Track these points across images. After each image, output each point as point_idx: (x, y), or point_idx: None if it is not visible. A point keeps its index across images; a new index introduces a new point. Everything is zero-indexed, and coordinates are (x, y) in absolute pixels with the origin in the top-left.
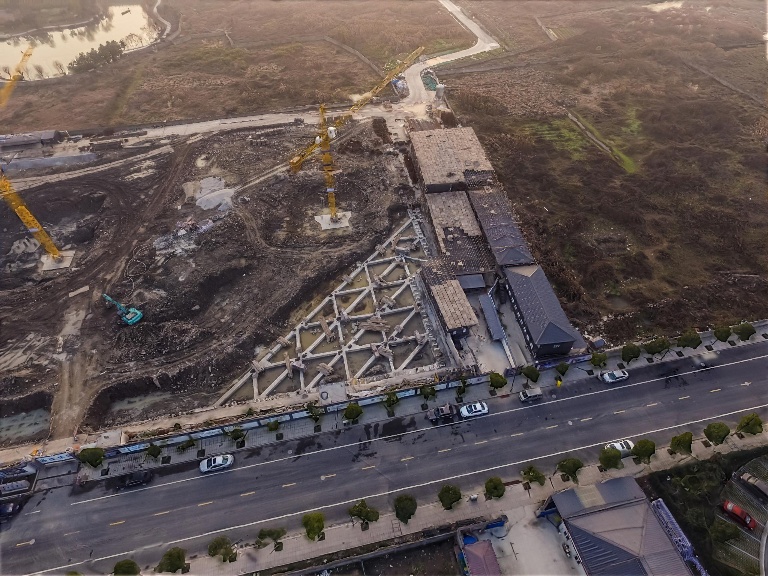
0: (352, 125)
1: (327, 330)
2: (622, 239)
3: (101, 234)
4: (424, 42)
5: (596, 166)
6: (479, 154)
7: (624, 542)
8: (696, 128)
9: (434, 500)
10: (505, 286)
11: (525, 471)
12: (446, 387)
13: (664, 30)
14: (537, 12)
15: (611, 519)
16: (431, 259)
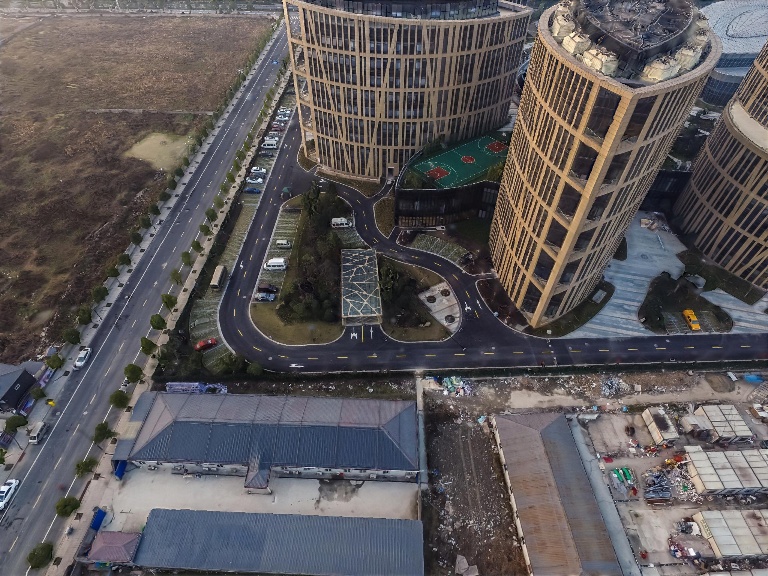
0: None
1: None
2: None
3: None
4: None
5: None
6: None
7: (163, 424)
8: None
9: (43, 575)
10: None
11: (77, 472)
12: None
13: None
14: None
15: (149, 424)
16: None
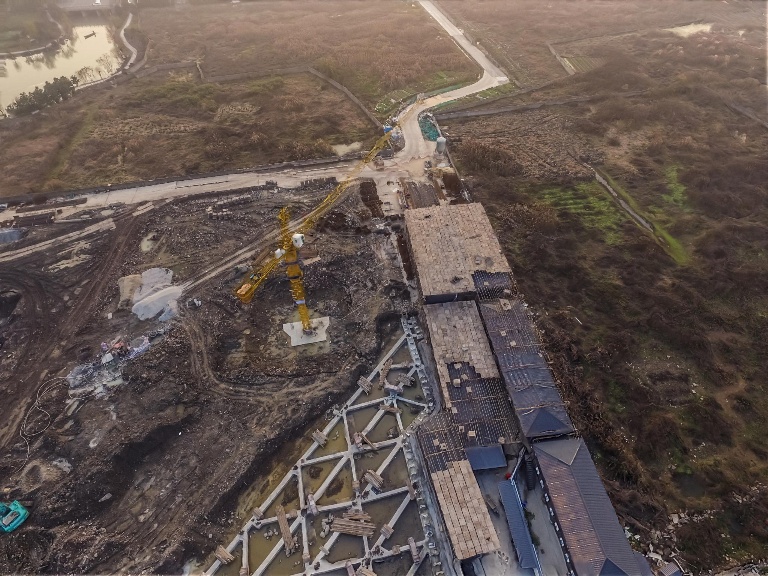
0: (335, 190)
1: (286, 534)
2: (683, 375)
3: (4, 358)
4: (422, 76)
5: (637, 255)
6: (492, 245)
7: None
8: (756, 199)
9: None
10: (534, 466)
11: None
12: None
13: (696, 61)
14: (549, 37)
15: None
16: (431, 421)
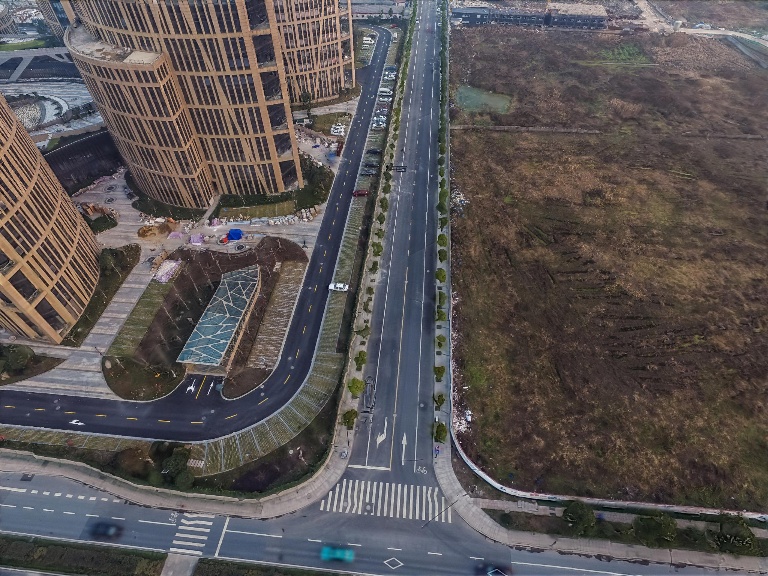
0: None
1: None
2: None
3: None
4: None
5: None
6: None
7: None
8: None
9: None
10: None
11: None
12: None
13: None
14: None
15: None
16: (501, 5)
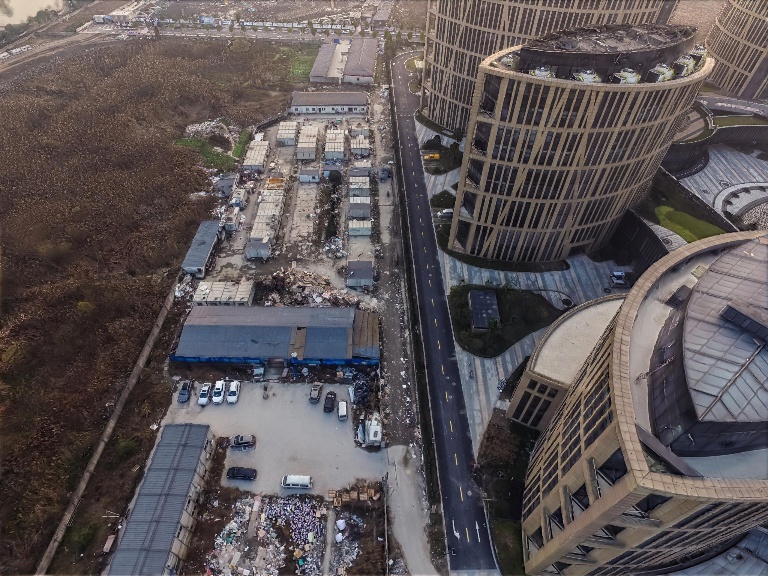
0: None
1: None
2: None
3: None
4: None
5: None
6: None
7: None
8: None
9: None
10: None
11: None
12: (341, 28)
13: None
14: None
15: None
16: (356, 8)
